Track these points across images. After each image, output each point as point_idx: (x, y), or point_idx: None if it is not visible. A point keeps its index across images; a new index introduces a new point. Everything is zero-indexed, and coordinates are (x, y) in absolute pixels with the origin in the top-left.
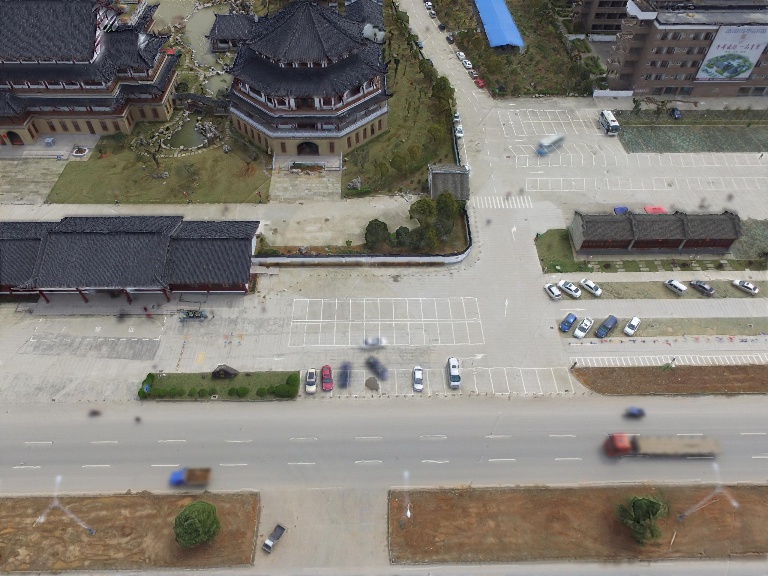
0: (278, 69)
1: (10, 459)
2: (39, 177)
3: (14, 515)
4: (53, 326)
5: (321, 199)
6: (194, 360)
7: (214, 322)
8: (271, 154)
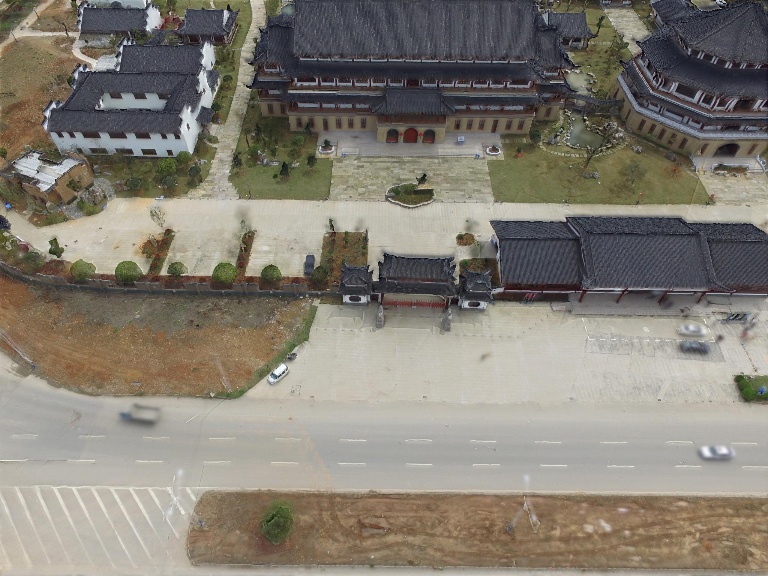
0: (721, 70)
1: (666, 458)
2: (470, 176)
3: (718, 514)
4: (601, 326)
5: (765, 202)
6: (767, 363)
7: (756, 325)
8: (685, 155)
